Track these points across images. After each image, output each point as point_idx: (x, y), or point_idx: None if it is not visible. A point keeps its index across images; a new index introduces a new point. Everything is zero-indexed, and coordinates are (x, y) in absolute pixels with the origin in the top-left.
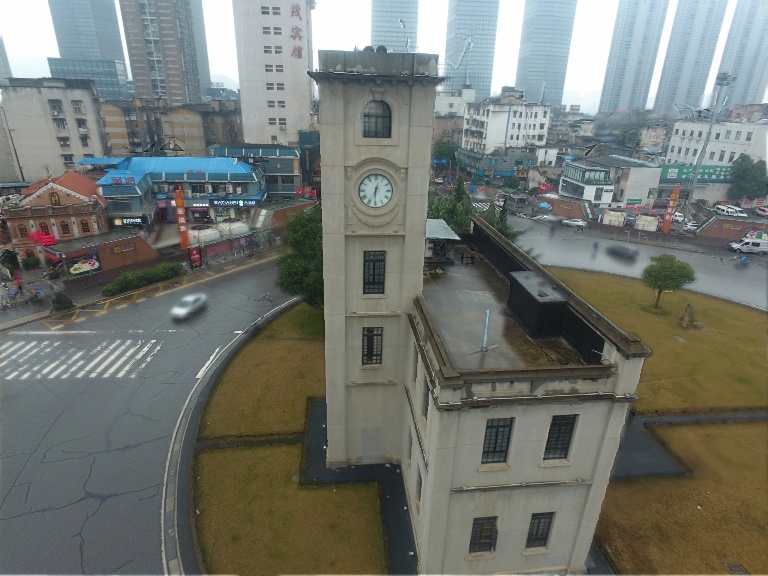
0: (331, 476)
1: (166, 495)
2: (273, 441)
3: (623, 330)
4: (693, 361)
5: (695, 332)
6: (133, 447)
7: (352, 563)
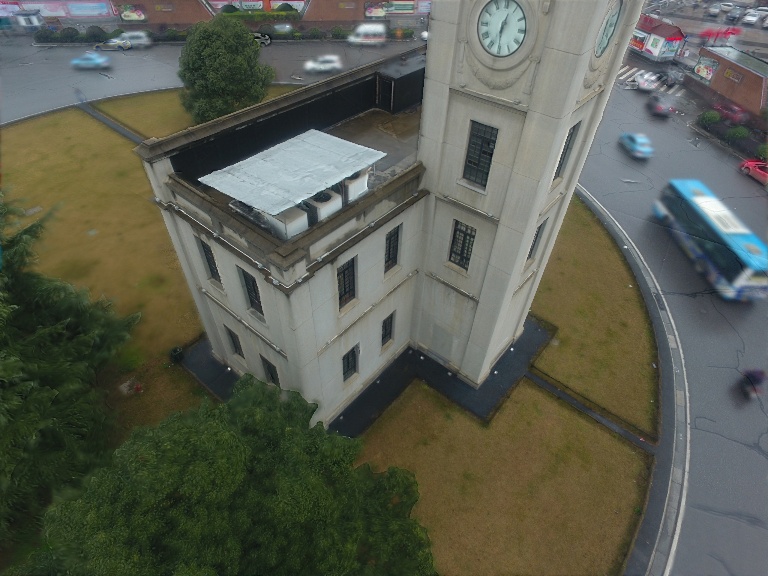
0: (524, 324)
1: (686, 410)
2: (560, 394)
3: (33, 247)
4: (100, 196)
5: (4, 203)
6: (743, 517)
7: (549, 268)
